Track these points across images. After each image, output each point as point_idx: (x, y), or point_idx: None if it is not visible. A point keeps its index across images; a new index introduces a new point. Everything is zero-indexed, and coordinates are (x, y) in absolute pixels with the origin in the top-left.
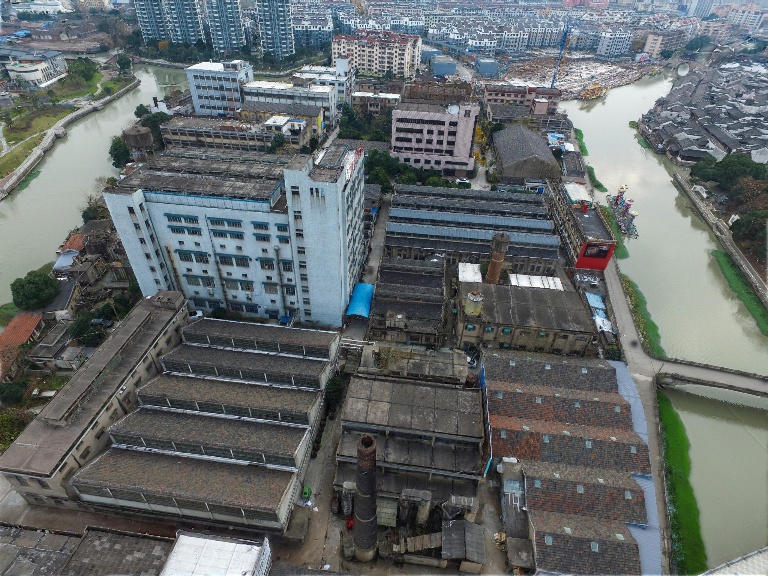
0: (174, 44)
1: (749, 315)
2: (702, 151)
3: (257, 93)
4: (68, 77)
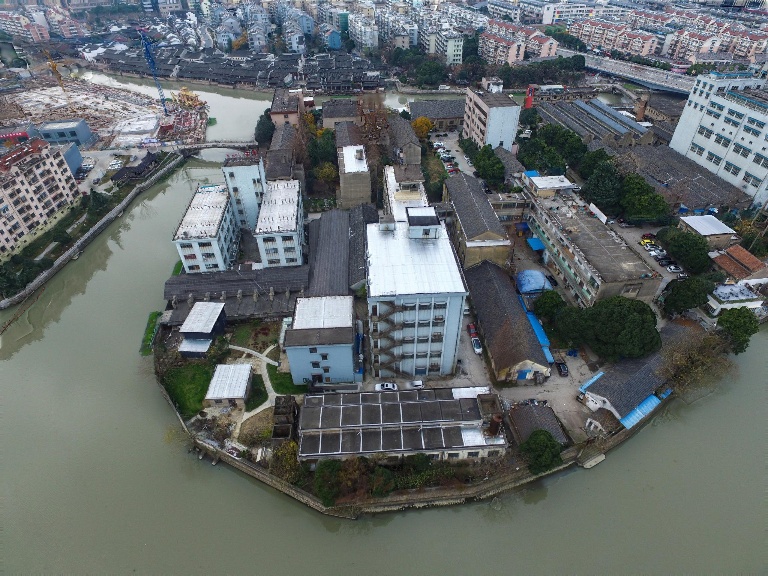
0: None
1: None
2: (379, 78)
3: None
4: None
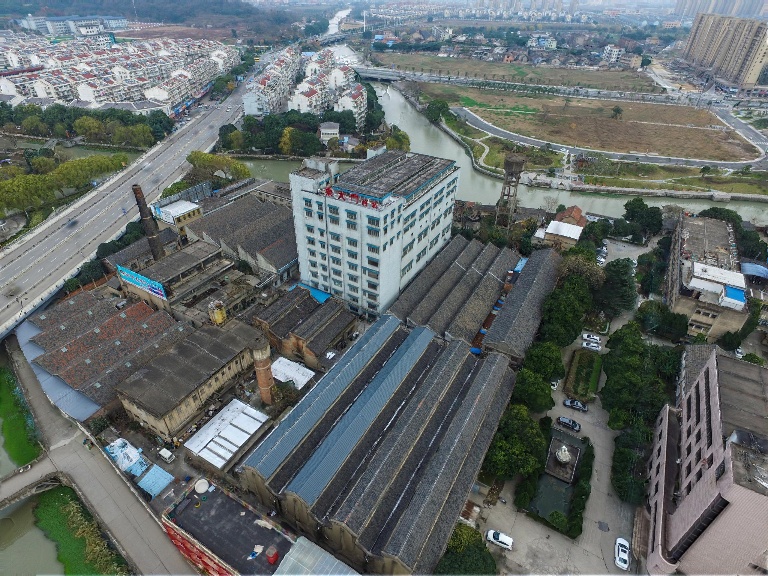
0: None
1: None
2: None
3: None
4: None
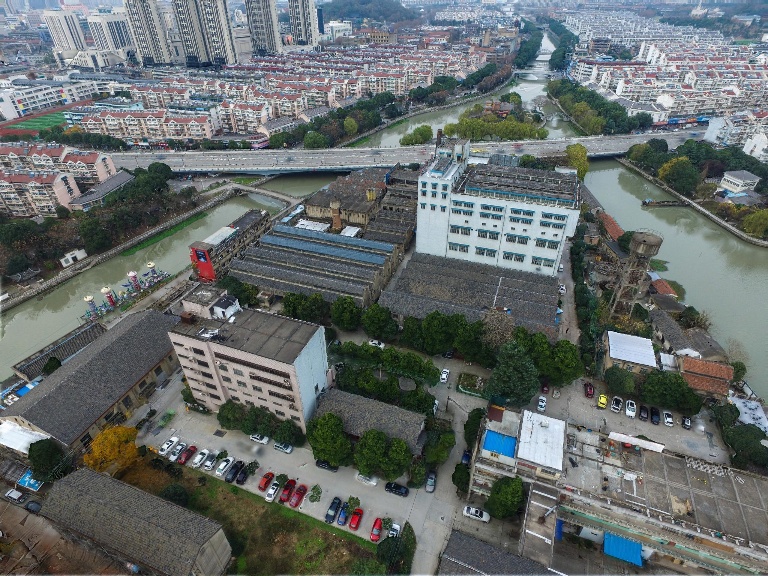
0: None
1: (157, 253)
2: None
3: None
4: None
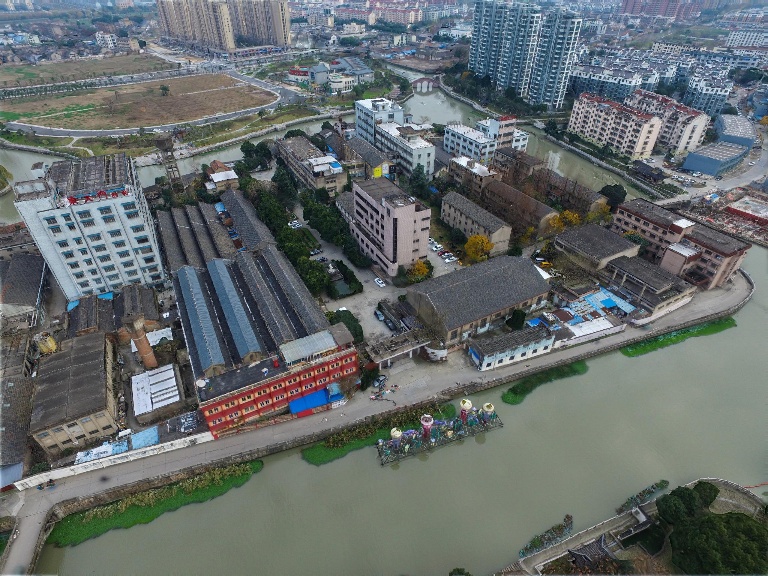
0: (472, 76)
1: None
2: None
3: (381, 133)
4: (352, 90)
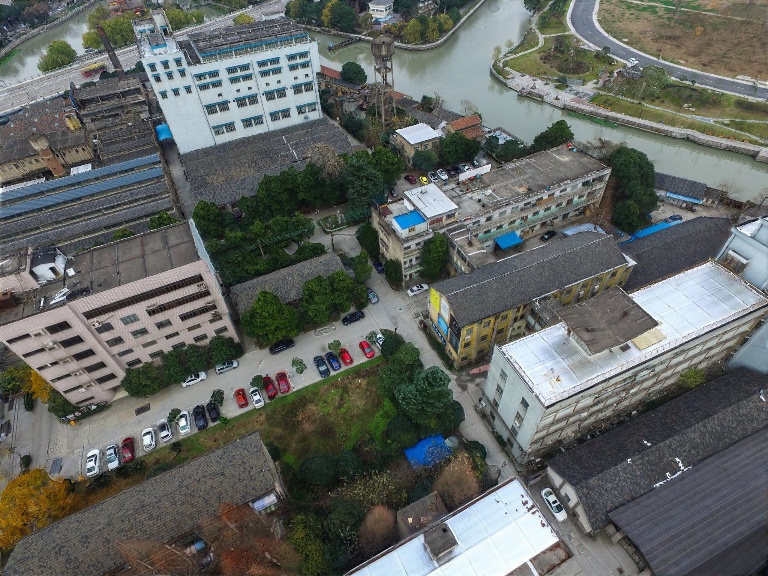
0: None
1: None
2: None
3: None
4: None
